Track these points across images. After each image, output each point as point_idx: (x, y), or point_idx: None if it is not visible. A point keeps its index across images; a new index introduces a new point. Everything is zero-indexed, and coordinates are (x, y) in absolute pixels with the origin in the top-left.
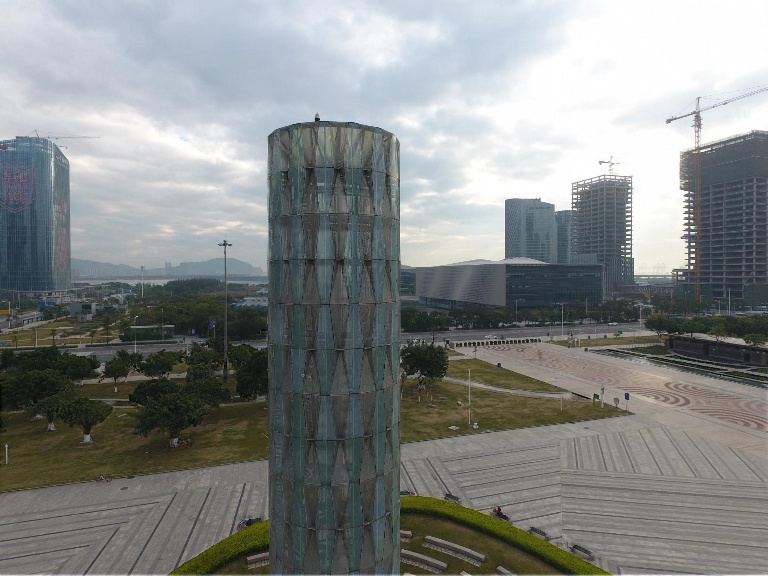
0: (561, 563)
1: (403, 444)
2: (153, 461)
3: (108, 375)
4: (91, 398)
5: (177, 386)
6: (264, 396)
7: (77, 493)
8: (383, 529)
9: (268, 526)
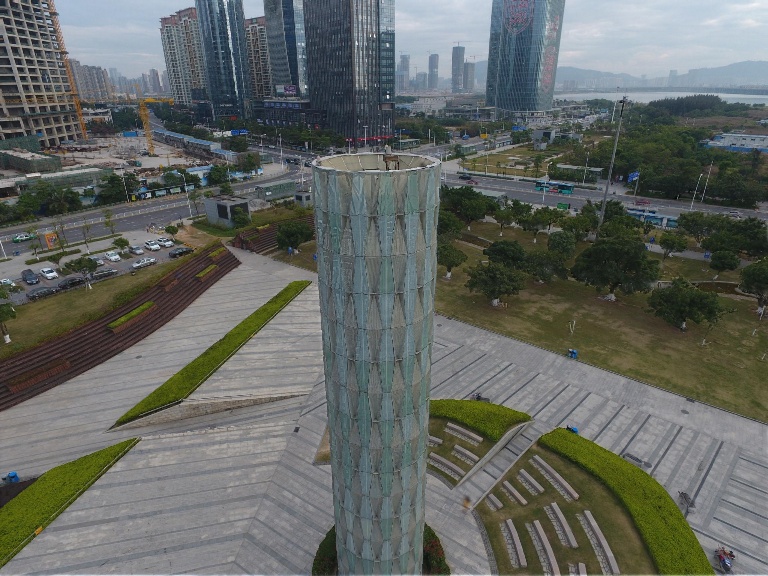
0: None
1: (714, 408)
2: (471, 312)
3: (497, 221)
4: (481, 237)
5: (522, 252)
6: (595, 286)
7: None
8: (370, 480)
9: (480, 410)
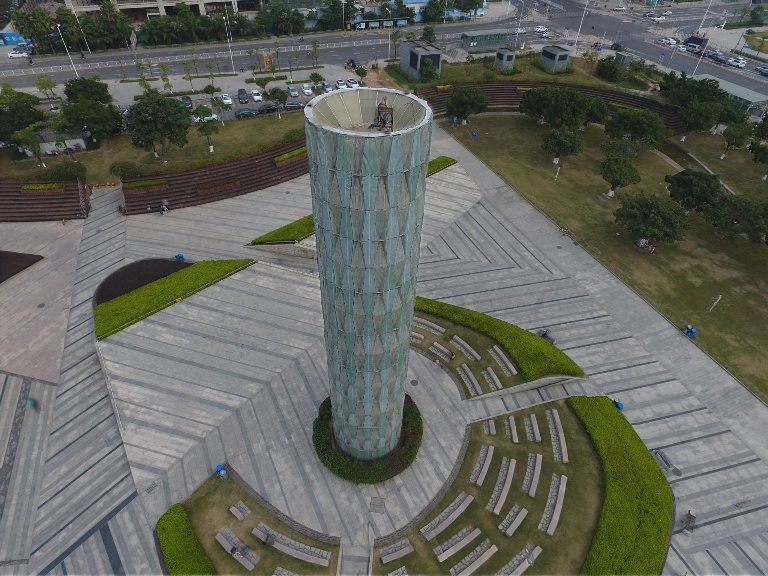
0: None
1: None
2: (606, 244)
3: (726, 138)
4: (693, 154)
5: (715, 192)
6: None
7: (541, 229)
8: (339, 368)
9: (534, 347)
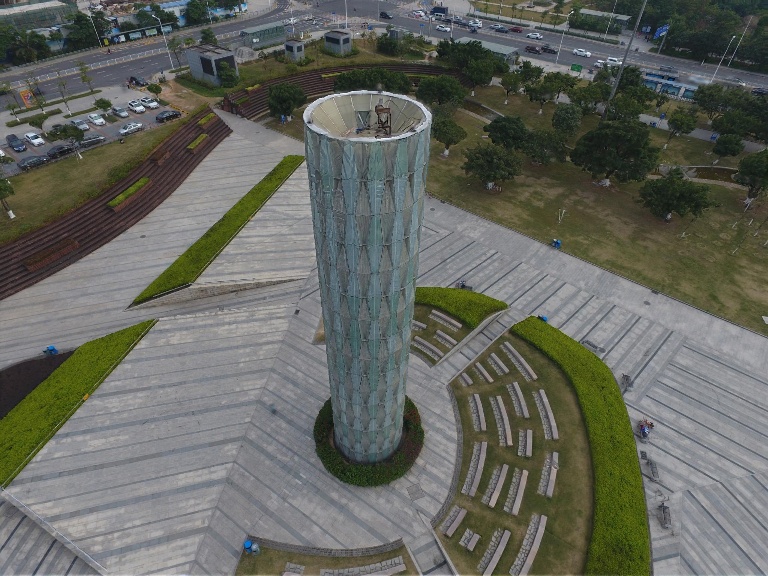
0: (597, 498)
1: (674, 300)
2: (465, 195)
3: (504, 86)
4: (485, 105)
5: (523, 131)
6: (592, 172)
7: None
8: (360, 380)
9: (463, 298)
